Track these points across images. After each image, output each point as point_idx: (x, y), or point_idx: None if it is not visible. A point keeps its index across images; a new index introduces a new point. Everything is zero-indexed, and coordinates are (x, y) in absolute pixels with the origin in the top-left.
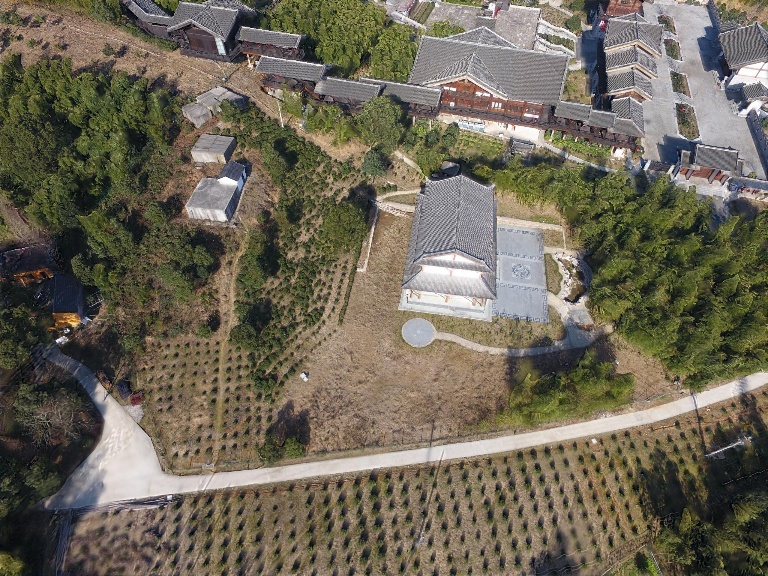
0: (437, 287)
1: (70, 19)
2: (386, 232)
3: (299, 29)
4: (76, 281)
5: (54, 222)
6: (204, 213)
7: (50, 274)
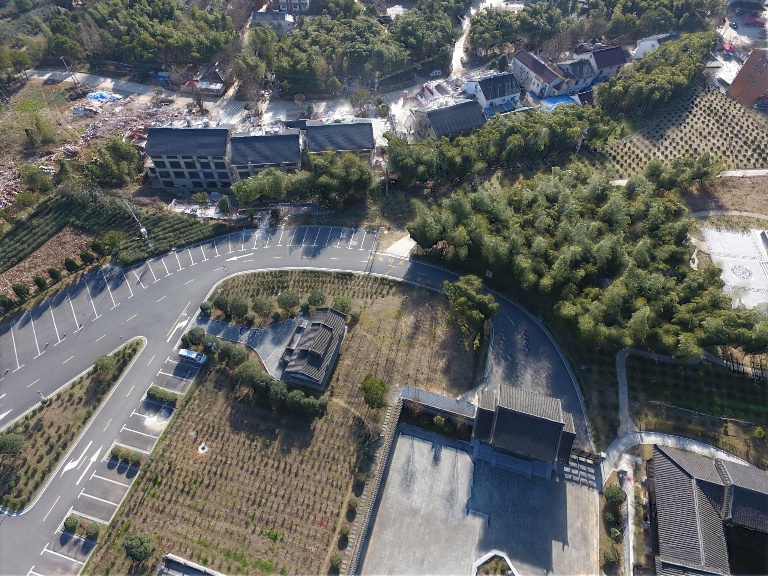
0: None
1: None
2: None
3: None
4: None
5: None
6: None
7: None
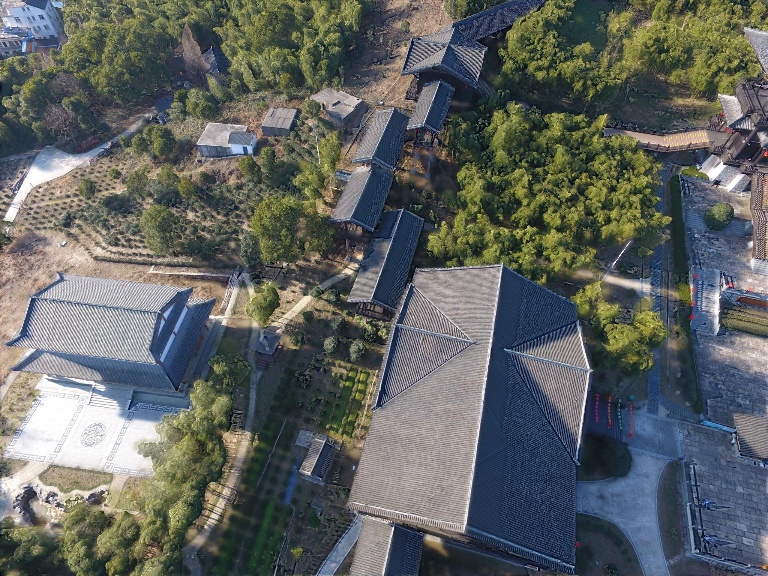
0: None
1: None
2: (199, 288)
3: None
4: None
5: None
6: None
7: None
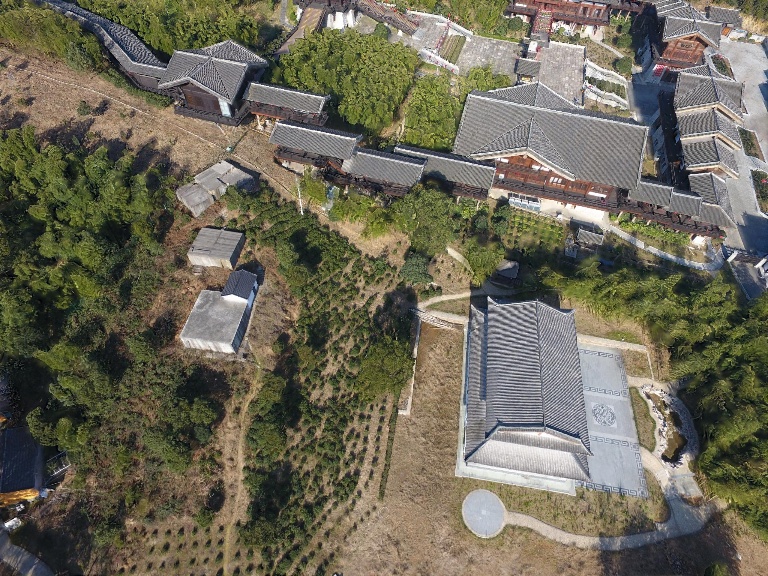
0: (512, 461)
1: (38, 63)
2: (431, 354)
3: (319, 81)
4: (33, 441)
5: (7, 350)
6: (204, 344)
7: (1, 418)
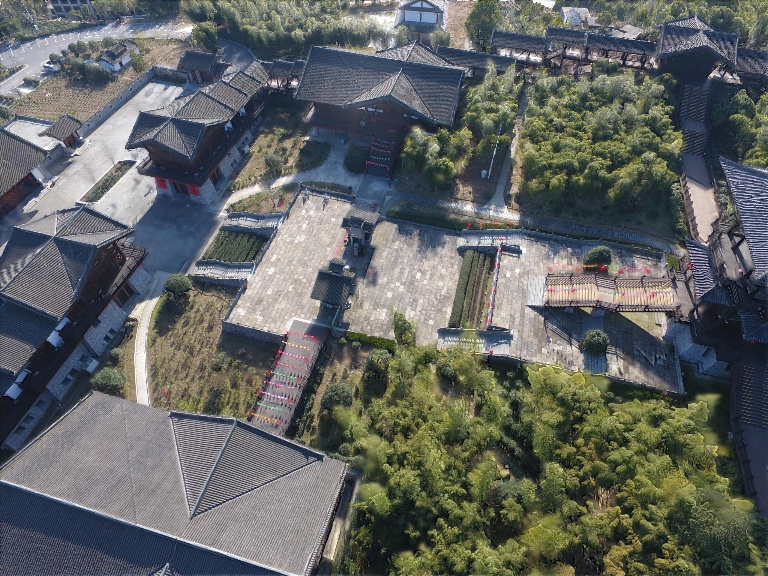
0: None
1: None
2: None
3: None
4: None
5: None
6: None
7: None
